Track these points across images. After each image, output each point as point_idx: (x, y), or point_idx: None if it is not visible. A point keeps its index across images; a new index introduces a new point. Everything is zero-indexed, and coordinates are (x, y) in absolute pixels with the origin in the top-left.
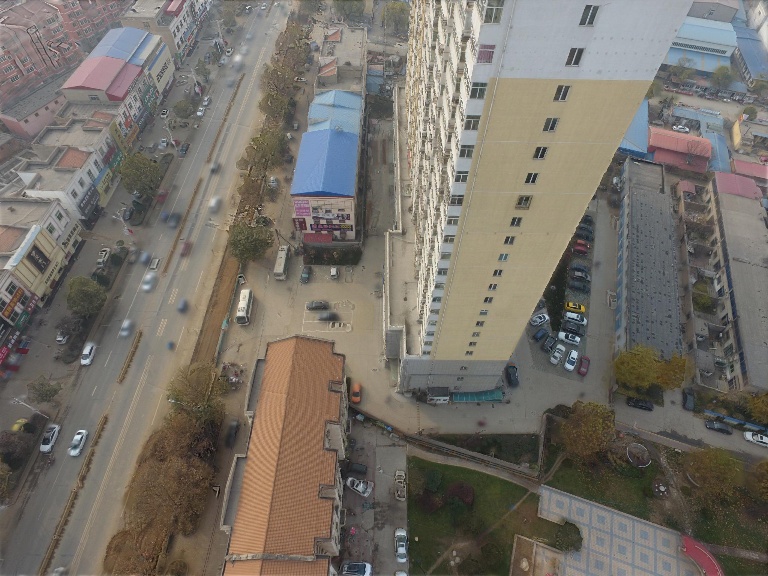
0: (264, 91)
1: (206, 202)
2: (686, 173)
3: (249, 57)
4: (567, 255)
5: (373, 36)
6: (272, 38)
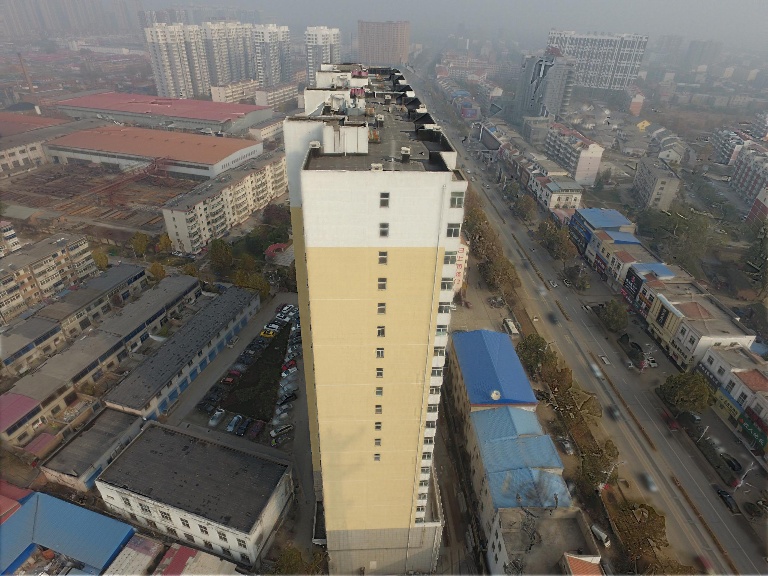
0: (691, 567)
1: (618, 417)
2: (19, 459)
3: None
4: (250, 370)
5: None
6: None
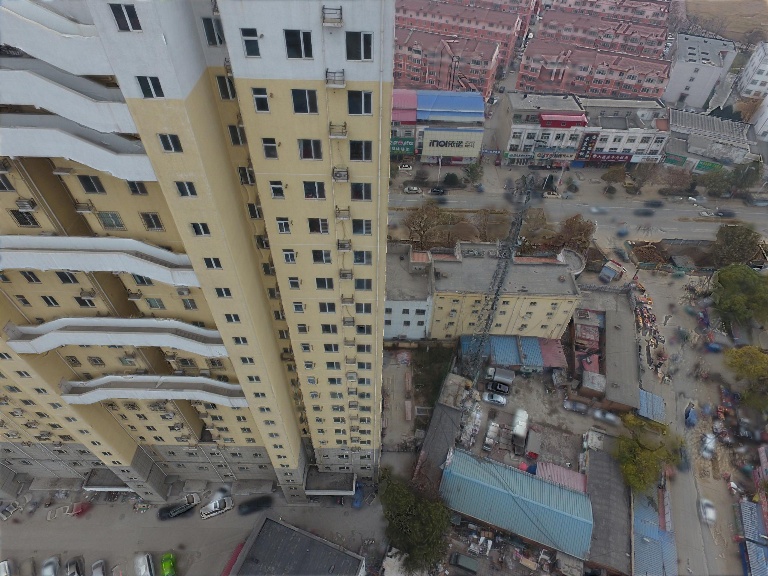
0: (406, 214)
1: None
2: None
3: (548, 213)
4: None
5: (702, 359)
6: (614, 230)
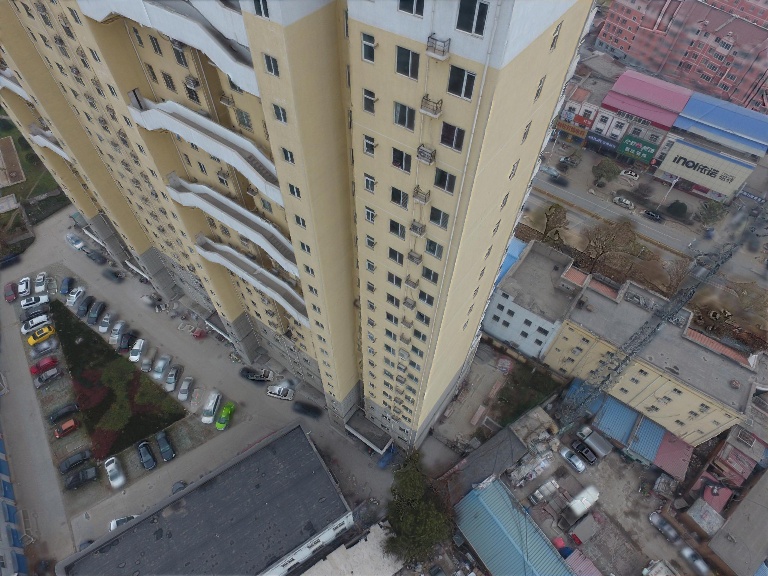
0: (594, 224)
1: None
2: None
3: None
4: (80, 391)
5: None
6: None
